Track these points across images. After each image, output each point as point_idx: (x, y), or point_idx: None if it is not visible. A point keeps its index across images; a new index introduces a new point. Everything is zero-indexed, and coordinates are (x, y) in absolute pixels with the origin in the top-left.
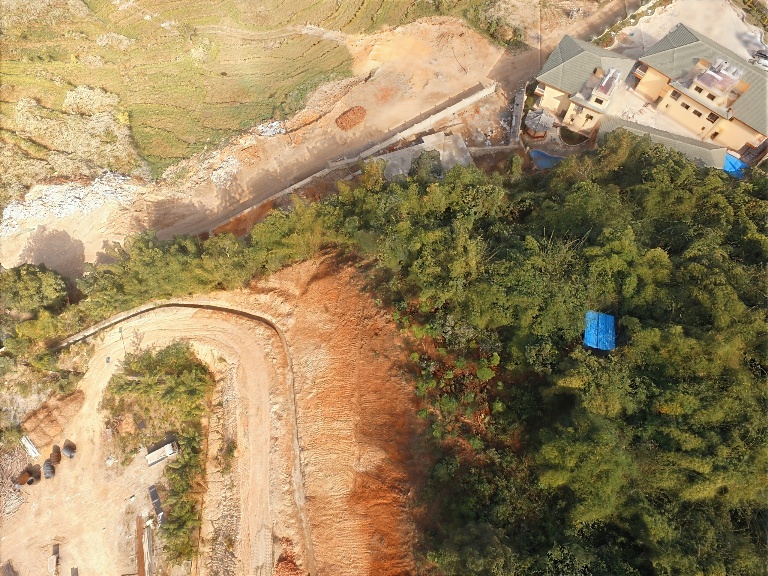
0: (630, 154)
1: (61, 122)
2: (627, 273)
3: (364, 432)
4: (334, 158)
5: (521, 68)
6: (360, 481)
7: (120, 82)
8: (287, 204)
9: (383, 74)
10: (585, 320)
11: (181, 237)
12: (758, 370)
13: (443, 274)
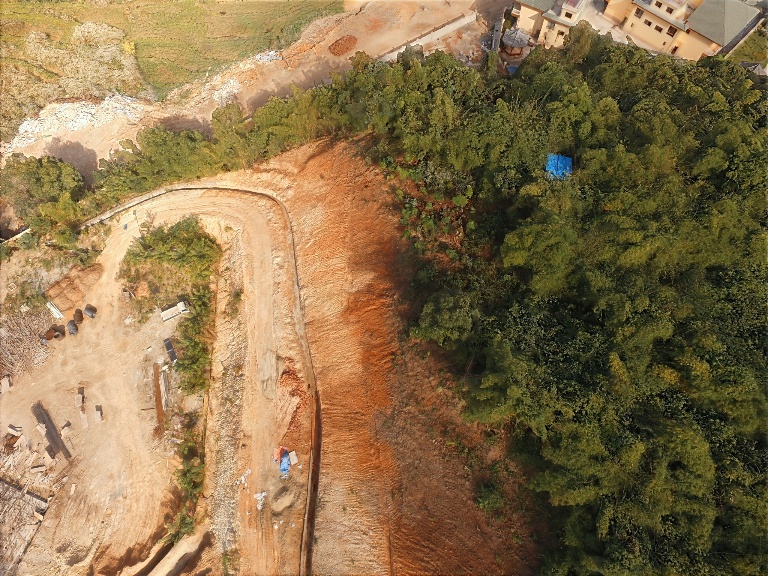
0: (592, 45)
1: (71, 52)
2: (583, 121)
3: (356, 262)
4: None
5: (501, 1)
6: (353, 299)
7: (125, 20)
8: None
9: (373, 8)
10: (546, 160)
11: (189, 130)
12: (688, 180)
13: (424, 127)
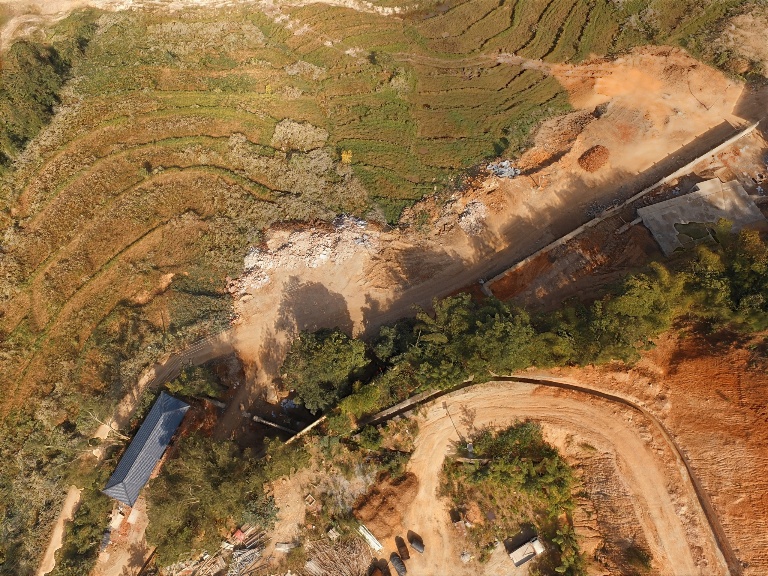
0: None
1: (280, 160)
2: None
3: None
4: (587, 203)
5: (767, 105)
6: None
7: (322, 115)
8: (563, 257)
9: (615, 110)
10: None
11: (501, 302)
12: None
13: None
